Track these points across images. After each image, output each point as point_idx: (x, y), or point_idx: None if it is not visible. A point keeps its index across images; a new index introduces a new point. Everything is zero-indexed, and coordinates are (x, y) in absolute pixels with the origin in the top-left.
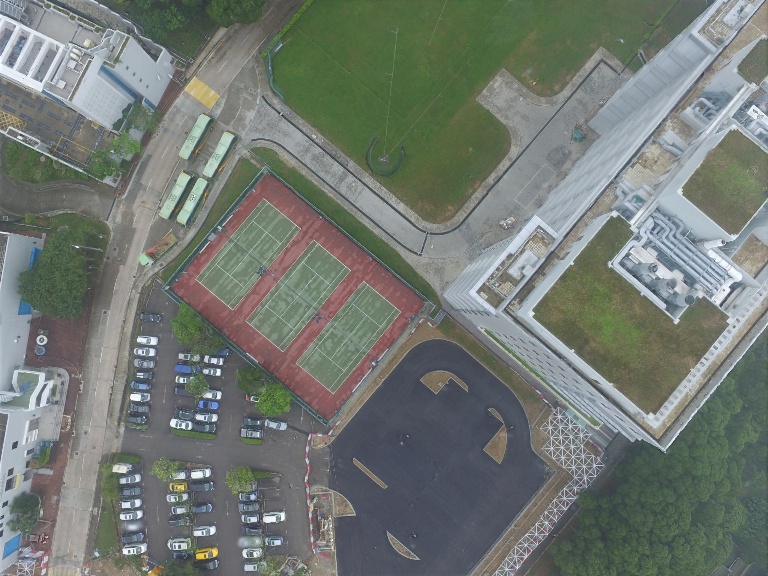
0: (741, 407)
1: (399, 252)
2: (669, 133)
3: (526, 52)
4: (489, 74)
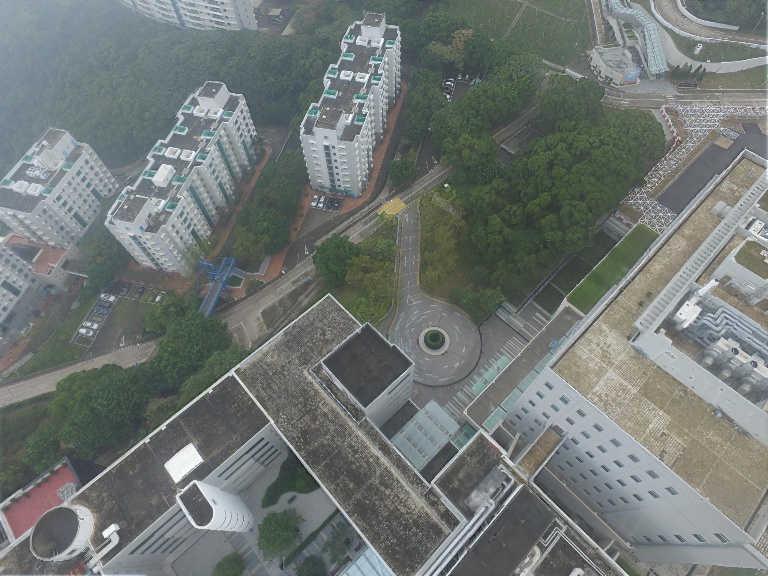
0: None
1: None
2: None
3: None
4: None
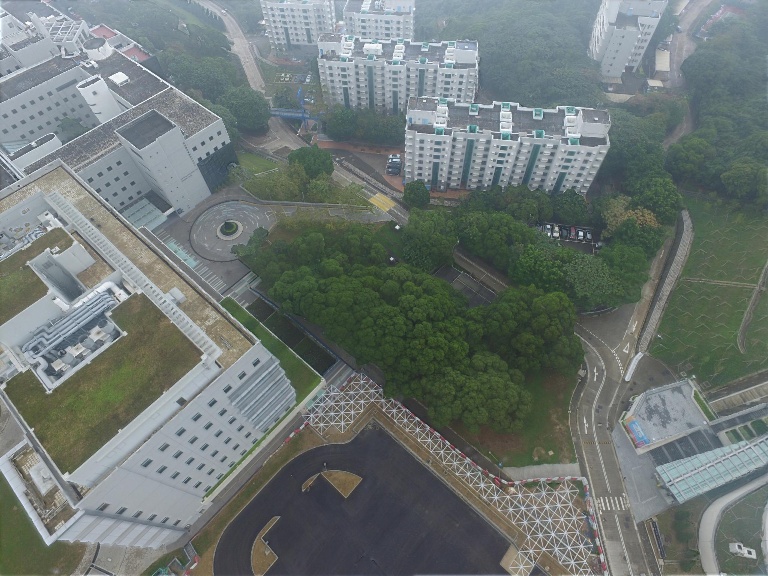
0: None
1: None
2: None
3: None
4: None
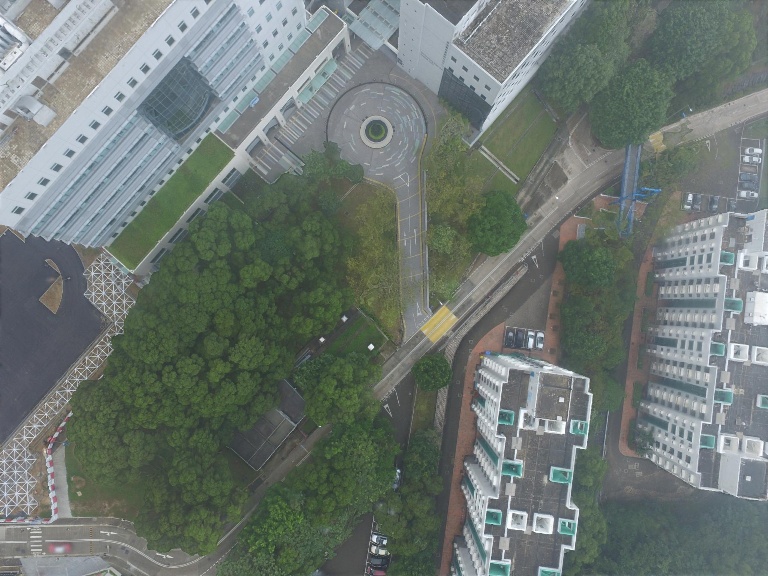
0: (292, 256)
1: None
2: None
3: None
4: None
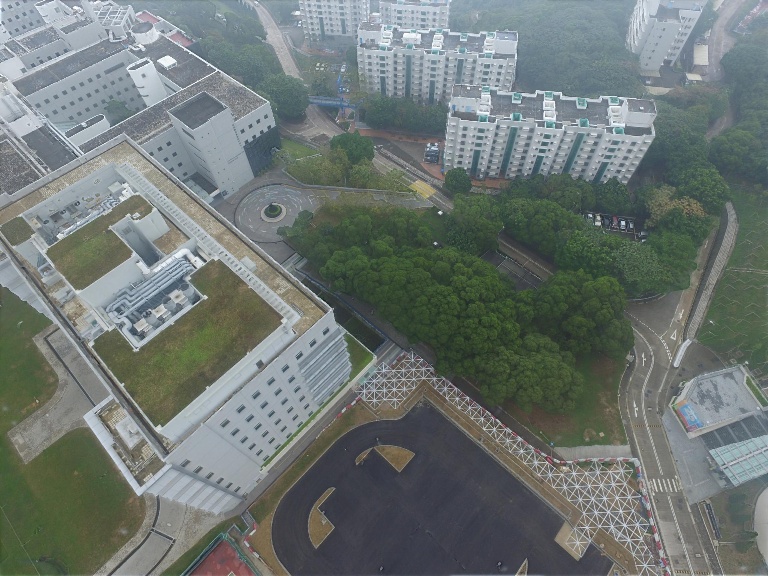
0: None
1: (163, 570)
2: (56, 295)
3: (2, 408)
4: (6, 448)
